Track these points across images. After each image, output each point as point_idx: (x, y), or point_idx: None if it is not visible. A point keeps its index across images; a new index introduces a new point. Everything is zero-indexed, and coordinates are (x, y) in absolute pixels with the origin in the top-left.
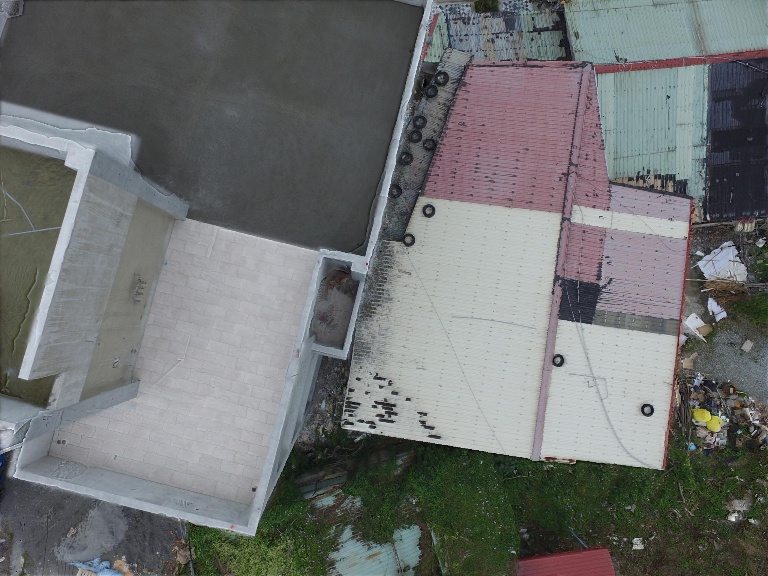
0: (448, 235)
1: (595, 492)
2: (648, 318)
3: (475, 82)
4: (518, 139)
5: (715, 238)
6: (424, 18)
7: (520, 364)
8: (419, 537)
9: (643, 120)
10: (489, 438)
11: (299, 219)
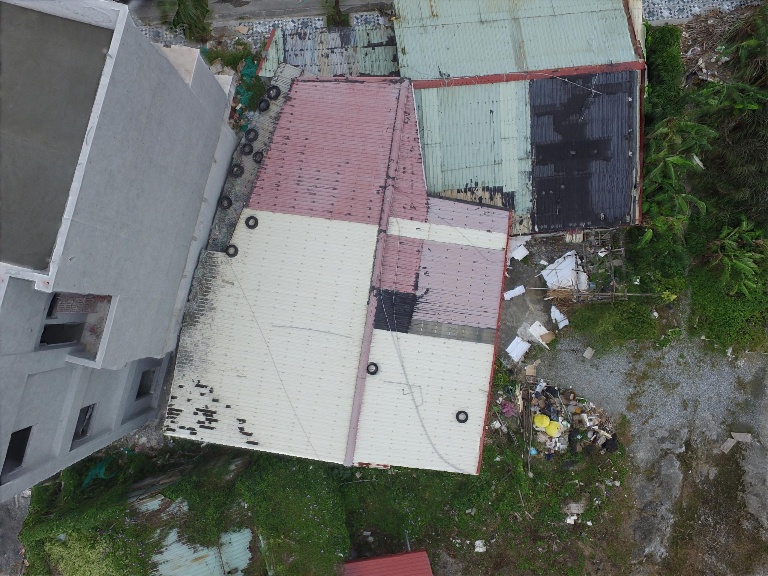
0: (270, 246)
1: (438, 496)
2: (465, 327)
3: (300, 97)
4: (339, 153)
5: (559, 248)
6: (111, 48)
7: (335, 372)
8: (250, 540)
9: (468, 134)
10: (304, 444)
11: (12, 238)
